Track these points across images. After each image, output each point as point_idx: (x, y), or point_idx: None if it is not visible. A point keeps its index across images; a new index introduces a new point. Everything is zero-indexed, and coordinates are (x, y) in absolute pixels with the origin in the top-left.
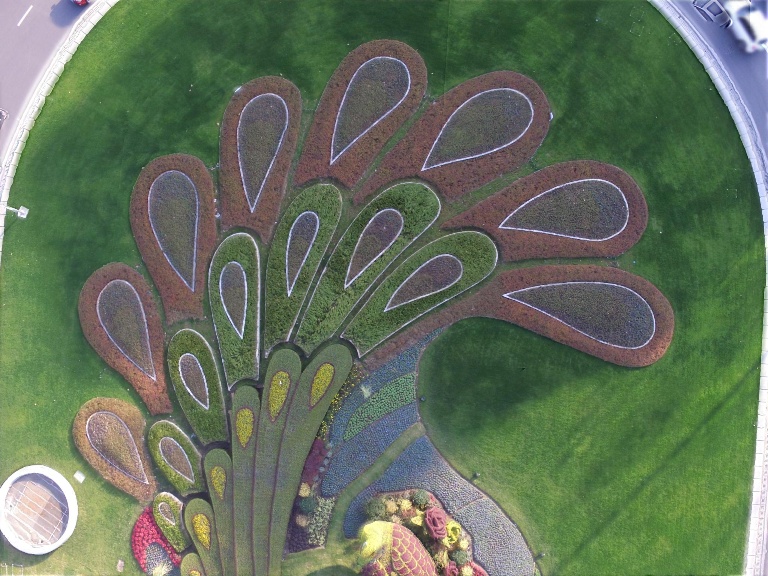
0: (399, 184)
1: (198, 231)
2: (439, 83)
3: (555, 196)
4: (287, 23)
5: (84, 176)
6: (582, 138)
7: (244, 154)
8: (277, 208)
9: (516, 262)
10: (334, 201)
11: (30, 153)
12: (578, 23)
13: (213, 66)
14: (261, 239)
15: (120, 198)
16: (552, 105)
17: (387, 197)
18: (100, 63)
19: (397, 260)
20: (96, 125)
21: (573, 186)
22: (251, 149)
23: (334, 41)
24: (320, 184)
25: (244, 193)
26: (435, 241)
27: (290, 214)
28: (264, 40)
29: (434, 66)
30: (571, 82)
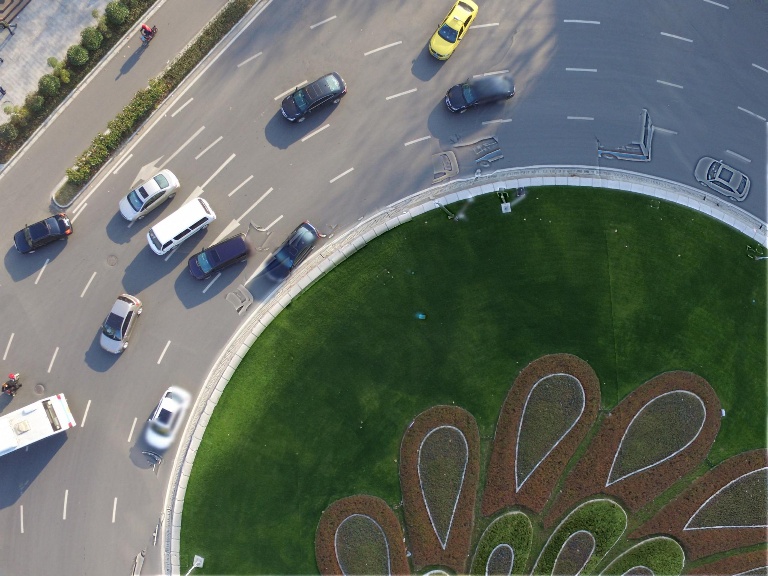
0: (586, 503)
1: (391, 573)
2: (612, 393)
3: (733, 491)
4: (451, 345)
5: (260, 523)
6: (752, 427)
7: (429, 492)
8: (469, 542)
9: (701, 558)
10: (526, 531)
11: (195, 501)
12: (737, 307)
13: (381, 399)
14: (457, 575)
15: (303, 544)
16: (722, 399)
17: (577, 520)
18: (257, 402)
19: (590, 575)
20: (265, 470)
21: (748, 478)
22: (436, 487)
23: (503, 361)
24: (509, 514)
25: (434, 531)
26: (626, 553)
27: (484, 549)
28: (430, 366)
29: (606, 376)
30: (737, 372)
